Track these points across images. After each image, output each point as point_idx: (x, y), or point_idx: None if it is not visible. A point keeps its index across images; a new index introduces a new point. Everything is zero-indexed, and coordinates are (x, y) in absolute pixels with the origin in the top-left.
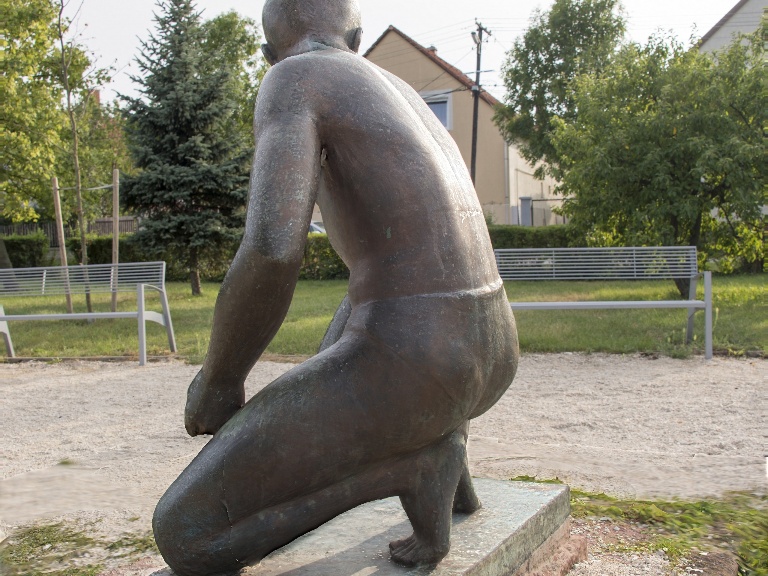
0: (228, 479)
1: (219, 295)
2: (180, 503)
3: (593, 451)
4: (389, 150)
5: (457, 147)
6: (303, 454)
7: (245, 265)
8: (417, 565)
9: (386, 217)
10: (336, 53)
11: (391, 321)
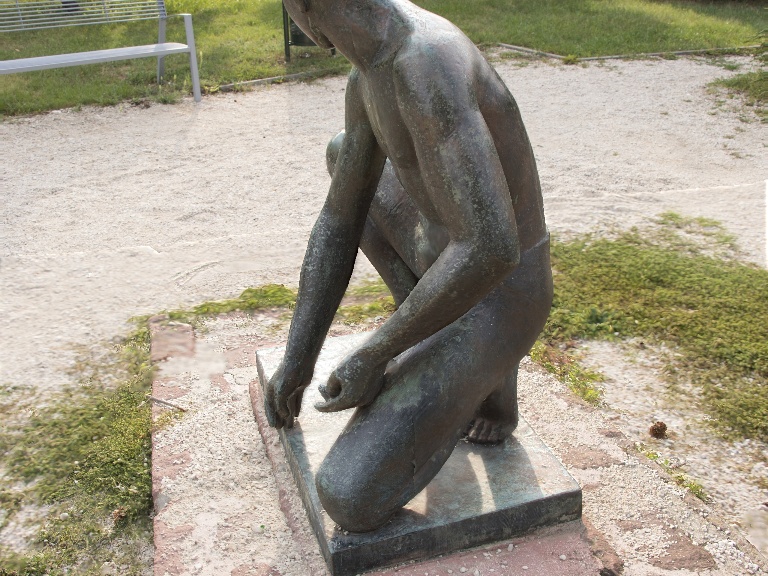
0: (419, 443)
1: (437, 298)
2: (375, 478)
3: (252, 241)
4: (516, 126)
5: None
6: (474, 401)
7: (483, 272)
8: (504, 441)
9: (517, 187)
10: (450, 25)
11: (523, 274)
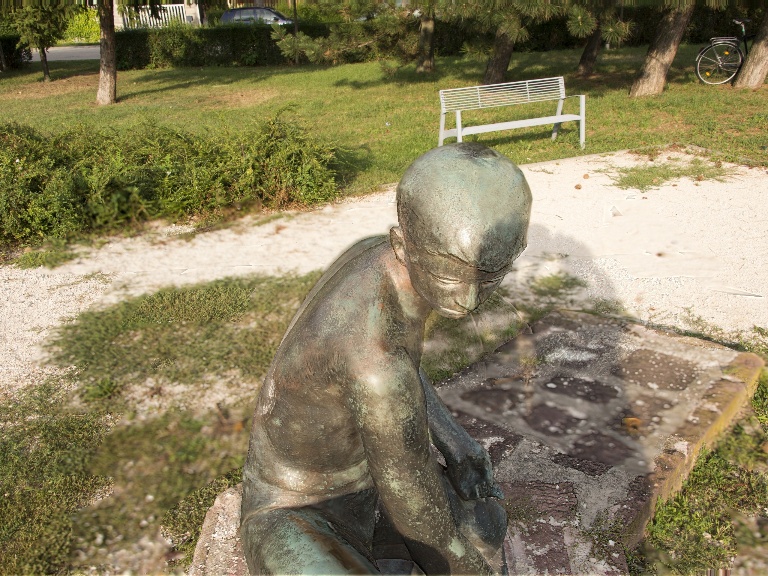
0: None
1: None
2: None
3: None
4: None
5: (278, 365)
6: None
7: None
8: None
9: None
10: None
11: None
